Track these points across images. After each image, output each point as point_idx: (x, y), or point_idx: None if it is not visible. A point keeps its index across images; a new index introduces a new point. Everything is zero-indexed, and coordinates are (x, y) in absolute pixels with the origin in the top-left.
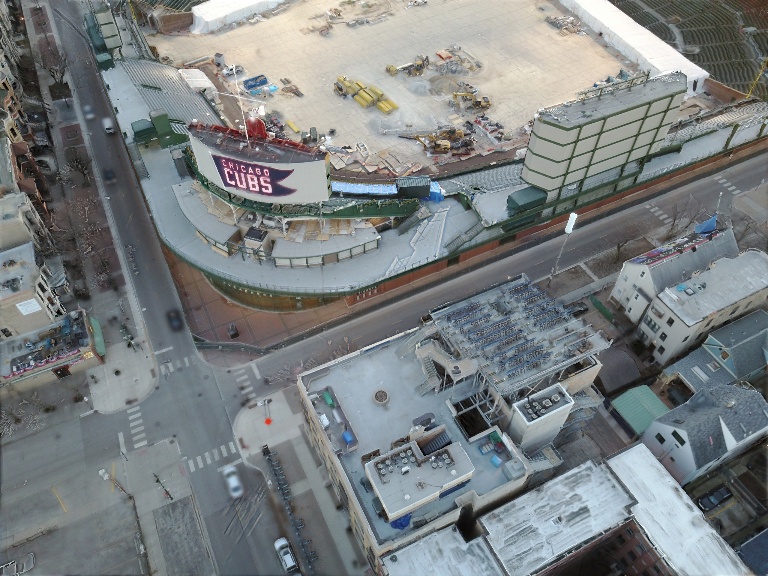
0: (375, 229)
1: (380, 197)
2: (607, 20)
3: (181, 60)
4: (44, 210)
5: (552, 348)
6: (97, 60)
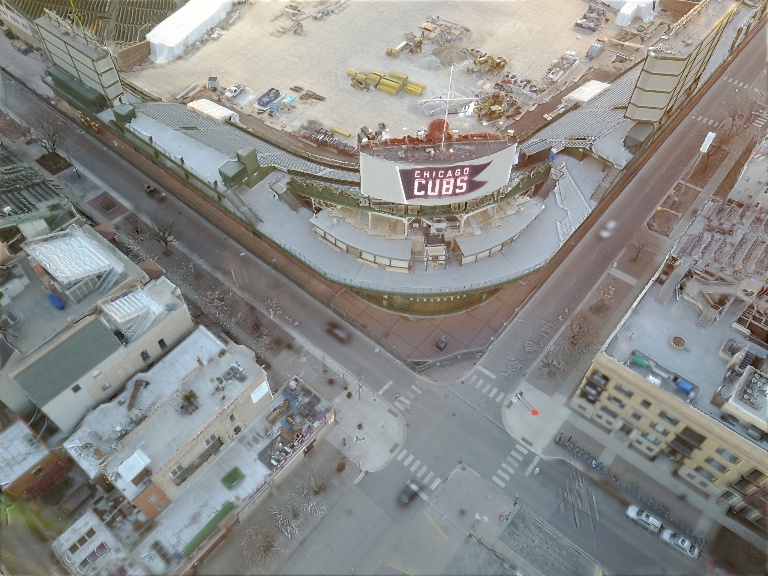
0: (534, 201)
1: None
2: None
3: (169, 94)
4: None
5: None
6: (118, 113)
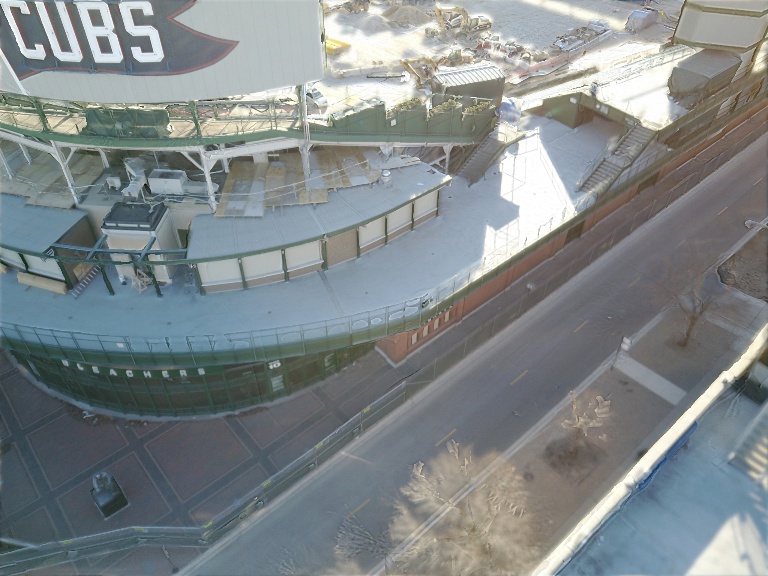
0: (429, 165)
1: None
2: None
3: None
4: None
5: None
6: None
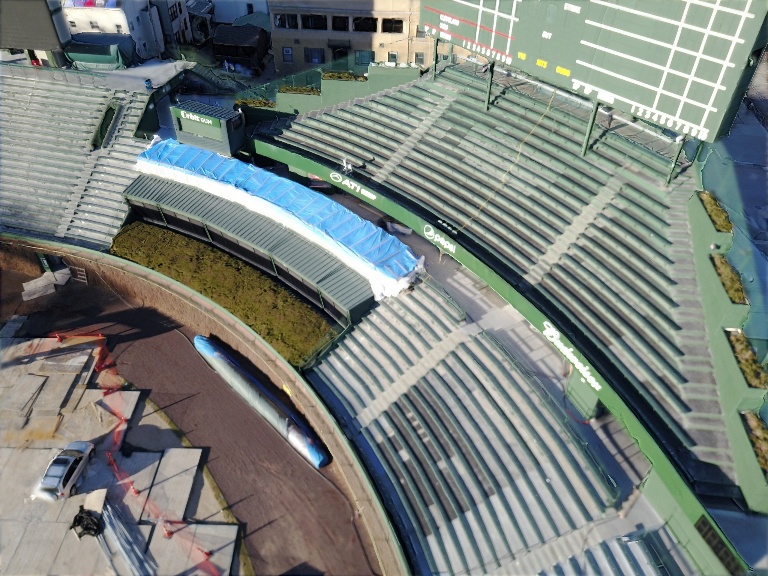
0: None
1: None
2: None
3: None
4: None
5: None
6: None
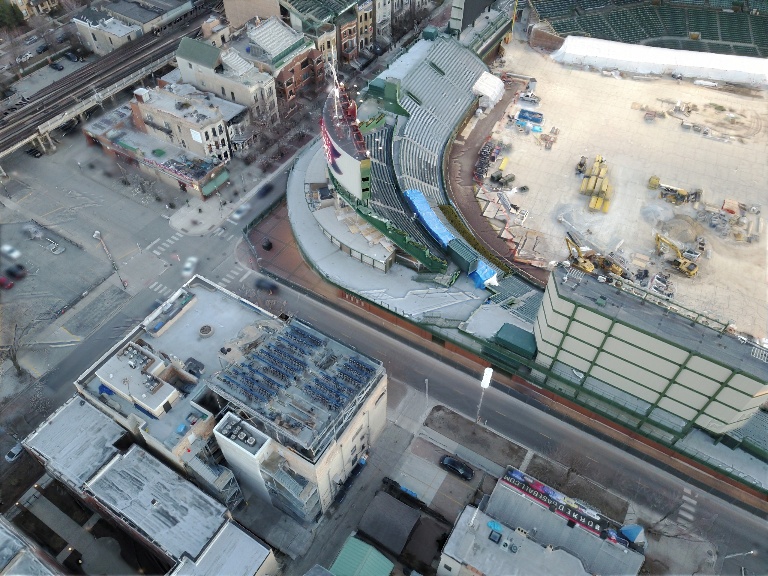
0: (390, 255)
1: (435, 242)
2: None
3: (510, 69)
4: (286, 99)
5: (282, 405)
6: (424, 29)
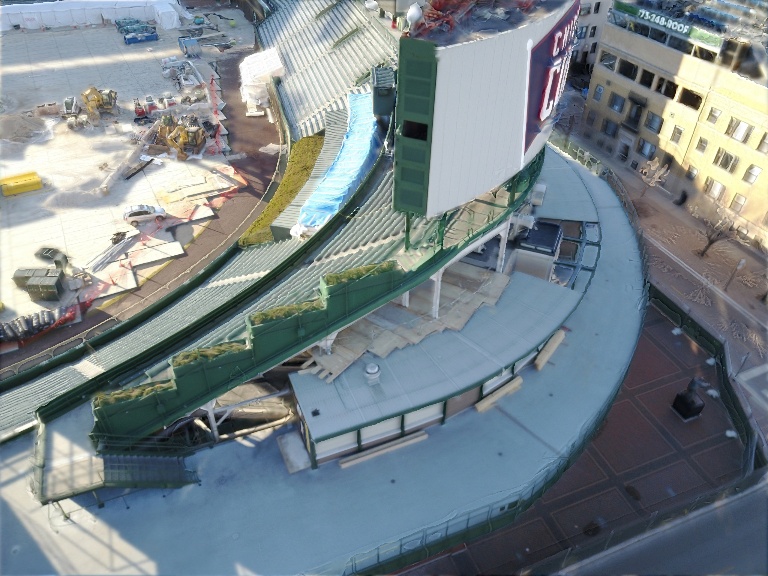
0: None
1: None
2: (4, 10)
3: None
4: None
5: None
6: None
